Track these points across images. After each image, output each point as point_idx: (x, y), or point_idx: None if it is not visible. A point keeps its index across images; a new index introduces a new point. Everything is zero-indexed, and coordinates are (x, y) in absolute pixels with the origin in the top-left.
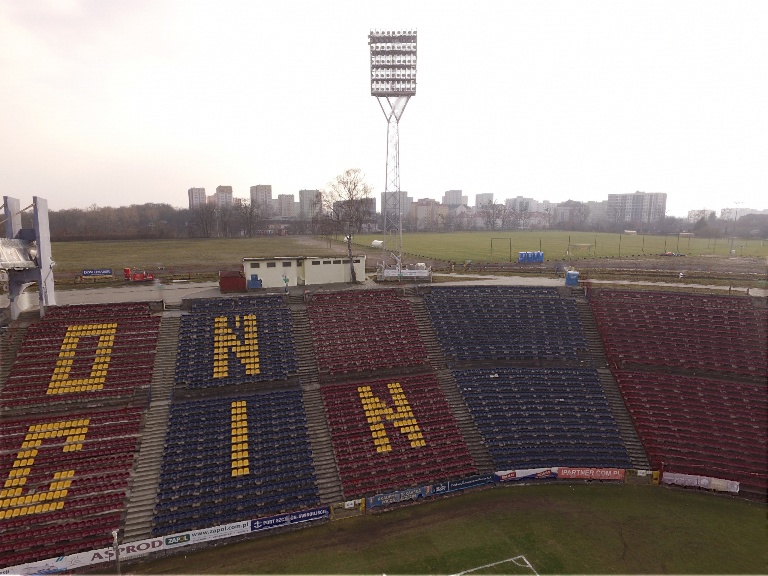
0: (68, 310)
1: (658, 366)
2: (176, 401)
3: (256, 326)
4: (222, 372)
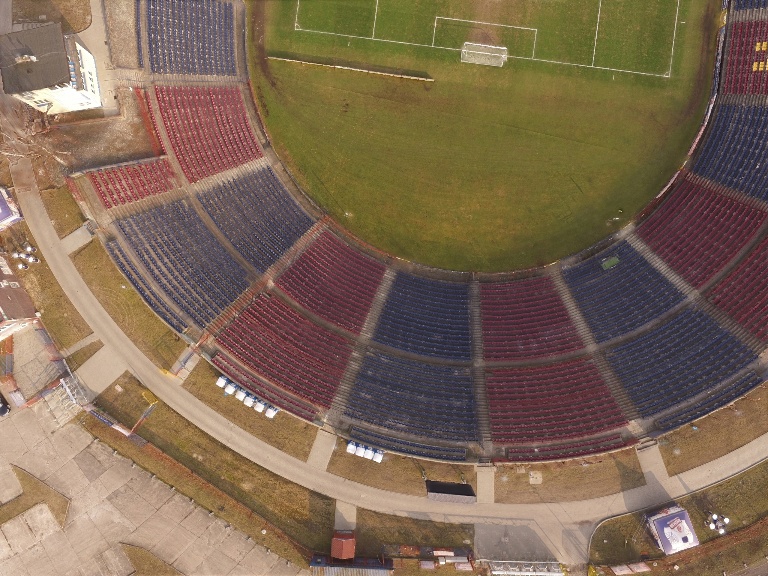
0: None
1: (759, 243)
2: None
3: None
4: None
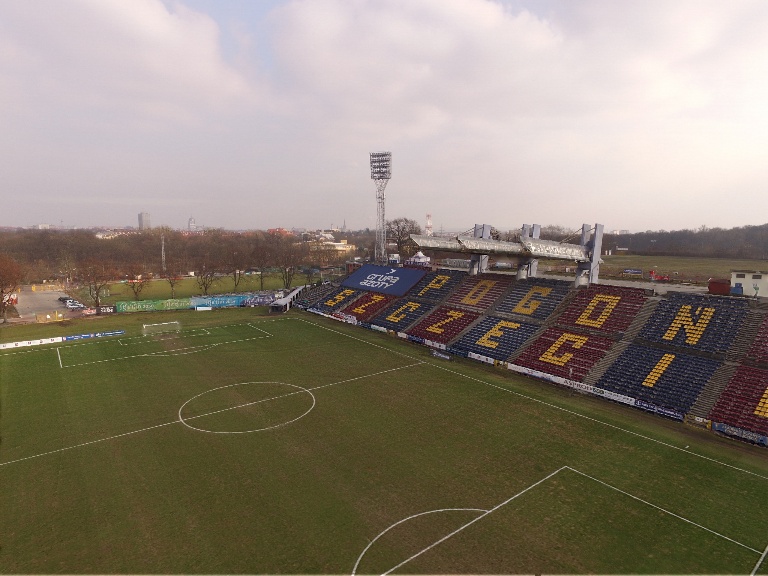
0: (600, 287)
1: None
2: (634, 344)
3: (712, 316)
4: (669, 337)
